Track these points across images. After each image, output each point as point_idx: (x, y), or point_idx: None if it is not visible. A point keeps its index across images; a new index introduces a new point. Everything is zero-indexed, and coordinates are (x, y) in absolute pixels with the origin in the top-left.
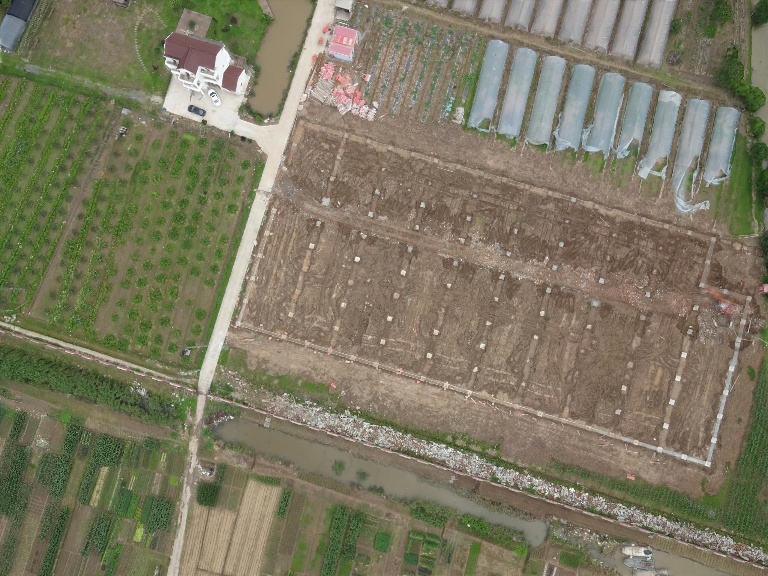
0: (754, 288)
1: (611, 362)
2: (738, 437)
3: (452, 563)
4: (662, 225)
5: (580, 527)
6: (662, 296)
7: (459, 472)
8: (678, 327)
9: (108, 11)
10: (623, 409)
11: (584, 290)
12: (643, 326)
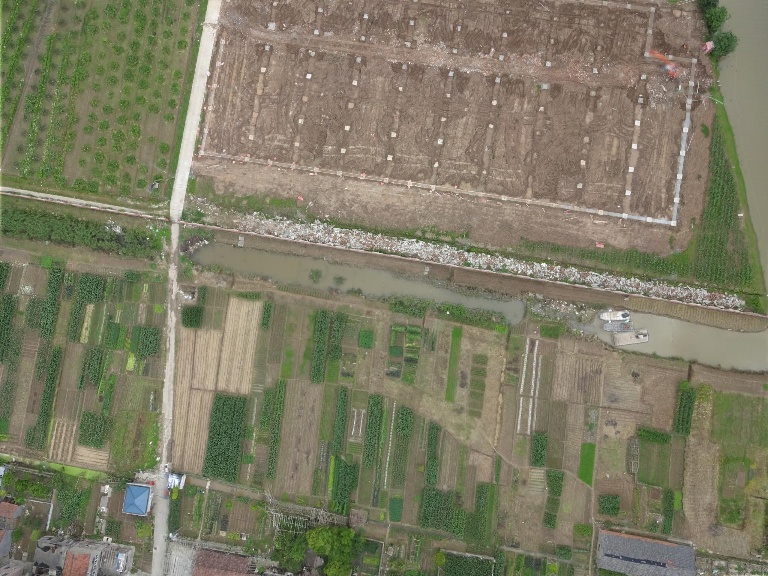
0: (698, 50)
1: (567, 139)
2: (700, 193)
3: (436, 350)
4: (601, 3)
5: (556, 300)
6: (609, 70)
7: (432, 261)
8: (628, 97)
9: None
10: (584, 182)
11: (532, 75)
12: (594, 101)
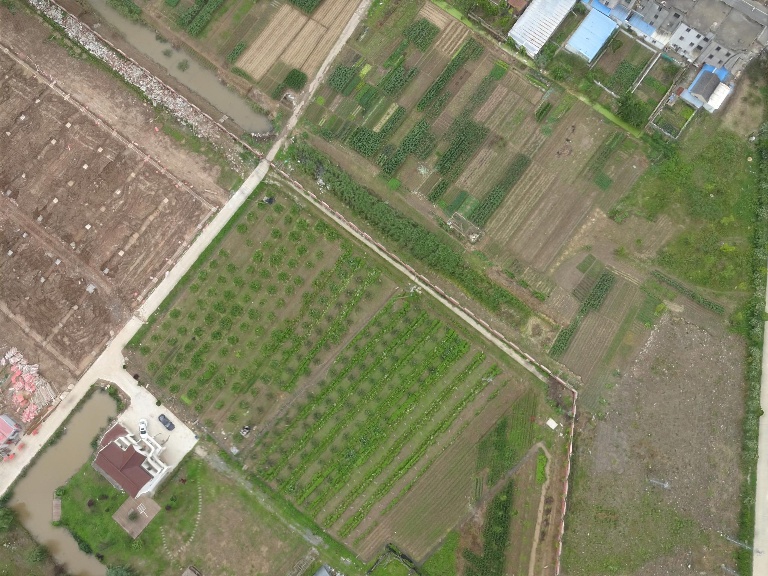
0: None
1: None
2: None
3: None
4: None
5: None
6: None
7: None
8: None
9: (212, 570)
10: None
11: None
12: None
